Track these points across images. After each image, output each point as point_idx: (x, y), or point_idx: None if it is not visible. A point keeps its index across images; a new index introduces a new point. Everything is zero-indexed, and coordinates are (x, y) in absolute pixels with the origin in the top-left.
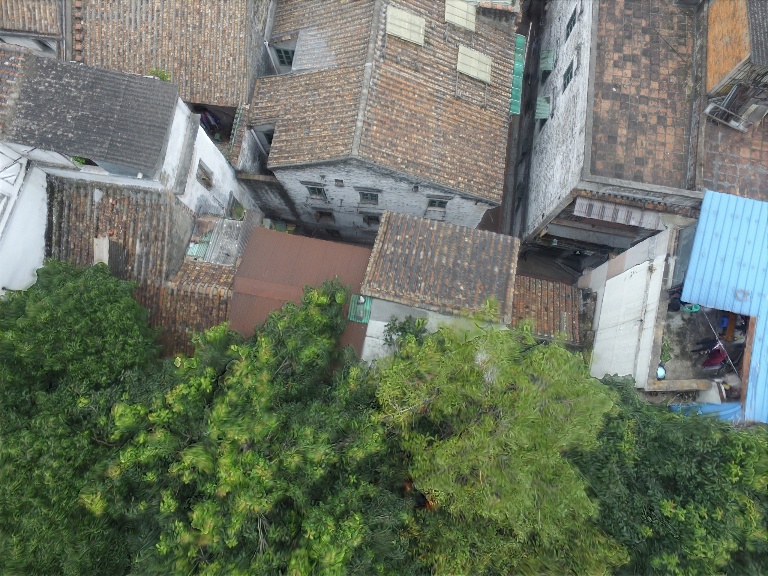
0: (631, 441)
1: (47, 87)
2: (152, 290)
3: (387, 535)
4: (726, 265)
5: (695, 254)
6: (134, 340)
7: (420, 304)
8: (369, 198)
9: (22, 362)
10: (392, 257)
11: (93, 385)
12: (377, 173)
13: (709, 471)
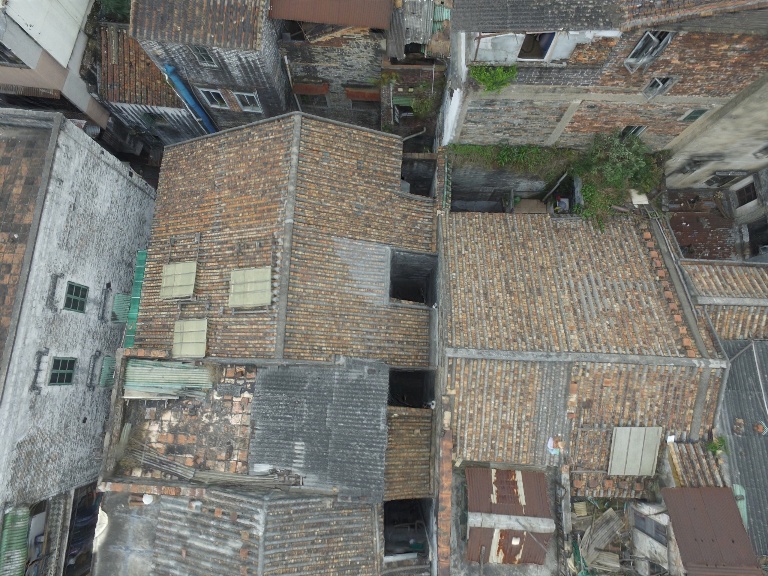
0: None
1: (590, 0)
2: None
3: None
4: None
5: None
6: None
7: None
8: None
9: None
10: None
11: None
12: None
13: None
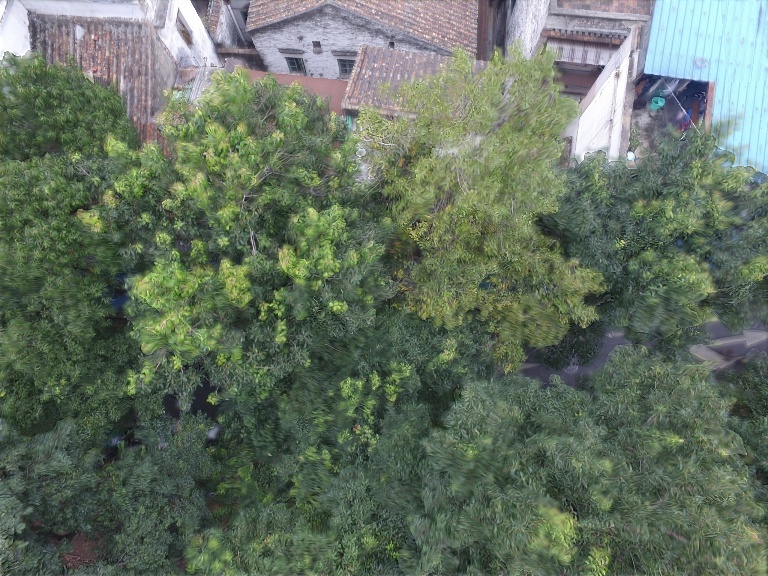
0: (602, 186)
1: None
2: (139, 128)
3: (375, 260)
4: (684, 36)
5: (655, 28)
6: (123, 121)
7: (399, 113)
8: (348, 71)
9: (15, 139)
10: (370, 79)
11: None
12: (353, 26)
13: (673, 180)
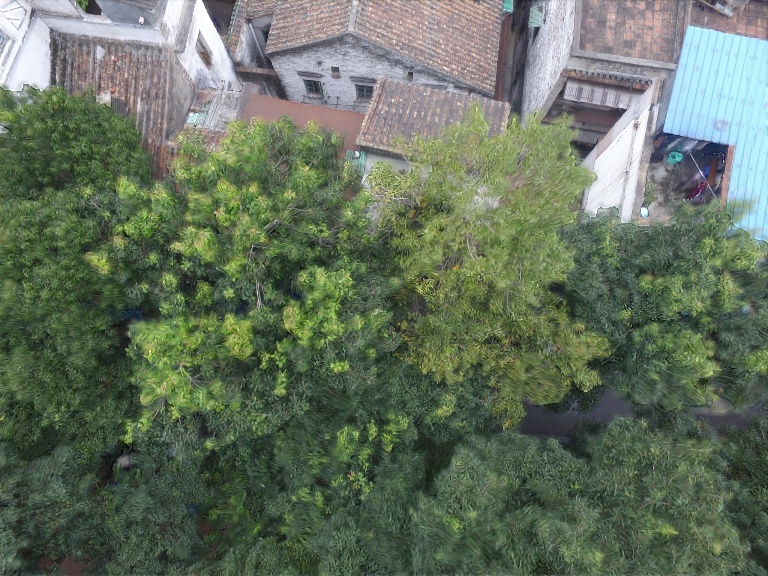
0: (613, 249)
1: None
2: (153, 150)
3: None
4: (706, 97)
5: (677, 87)
6: (137, 154)
7: (413, 153)
8: (365, 96)
9: (29, 168)
10: (386, 116)
11: (97, 192)
12: (372, 55)
13: (685, 253)
